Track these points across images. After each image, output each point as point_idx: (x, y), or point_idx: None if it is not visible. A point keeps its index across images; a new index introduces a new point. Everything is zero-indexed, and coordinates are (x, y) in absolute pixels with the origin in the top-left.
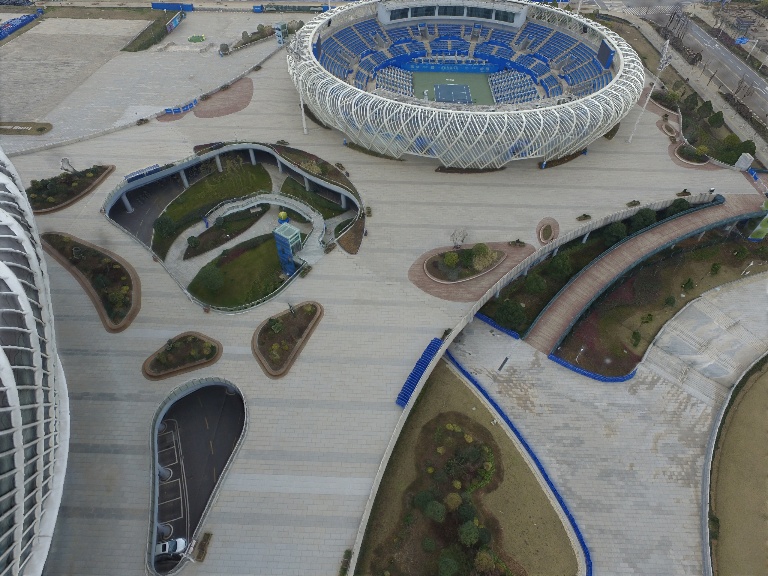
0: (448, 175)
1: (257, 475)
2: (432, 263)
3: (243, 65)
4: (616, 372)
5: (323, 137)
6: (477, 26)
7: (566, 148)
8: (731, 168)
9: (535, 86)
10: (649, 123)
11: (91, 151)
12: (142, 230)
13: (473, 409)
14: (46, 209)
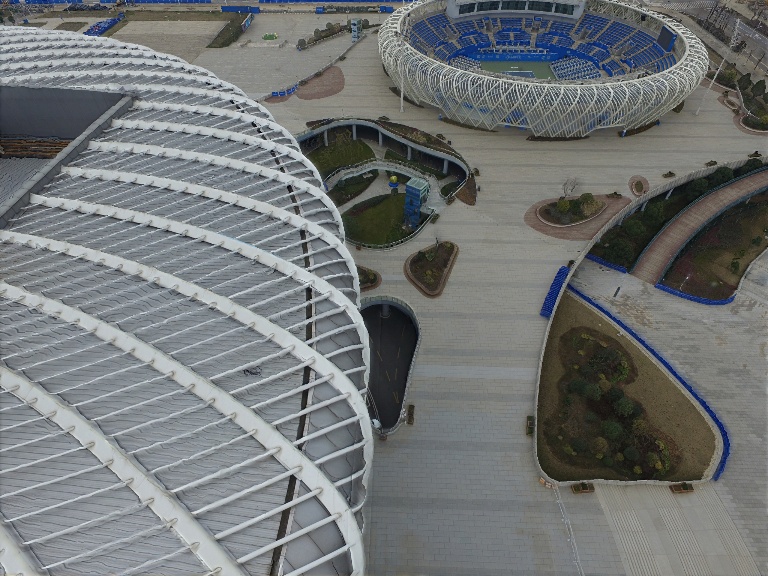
0: (539, 143)
1: (438, 366)
2: (545, 210)
3: (321, 58)
4: (717, 297)
5: (418, 114)
6: (537, 19)
7: (644, 118)
8: None
9: (598, 70)
10: (711, 99)
11: None
12: None
13: (599, 325)
14: None
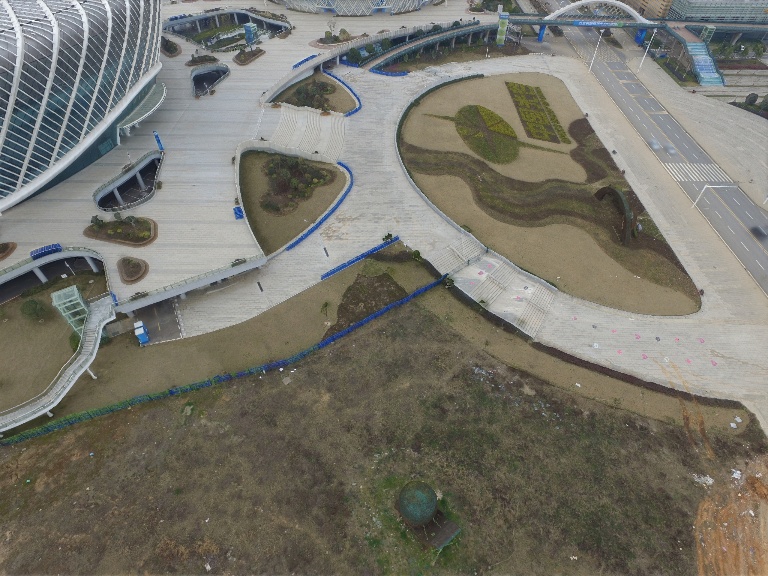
0: (340, 18)
1: (233, 82)
2: (320, 39)
3: None
4: None
5: (275, 7)
6: None
7: (403, 3)
8: (494, 14)
9: None
10: (463, 1)
11: None
12: None
13: (329, 81)
14: None
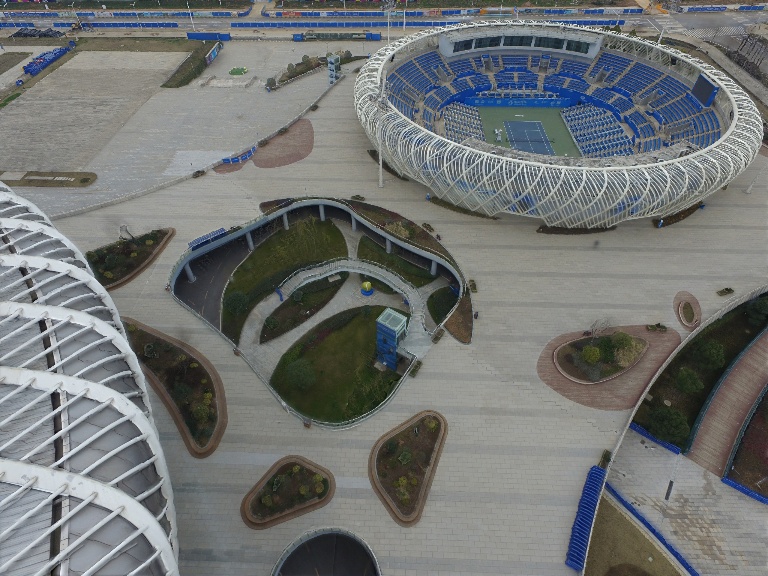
0: (553, 237)
1: None
2: (565, 357)
3: (293, 101)
4: None
5: (401, 190)
6: (545, 57)
7: (686, 204)
8: None
9: (619, 123)
10: None
11: (146, 211)
12: (208, 304)
13: (649, 560)
14: (104, 286)
